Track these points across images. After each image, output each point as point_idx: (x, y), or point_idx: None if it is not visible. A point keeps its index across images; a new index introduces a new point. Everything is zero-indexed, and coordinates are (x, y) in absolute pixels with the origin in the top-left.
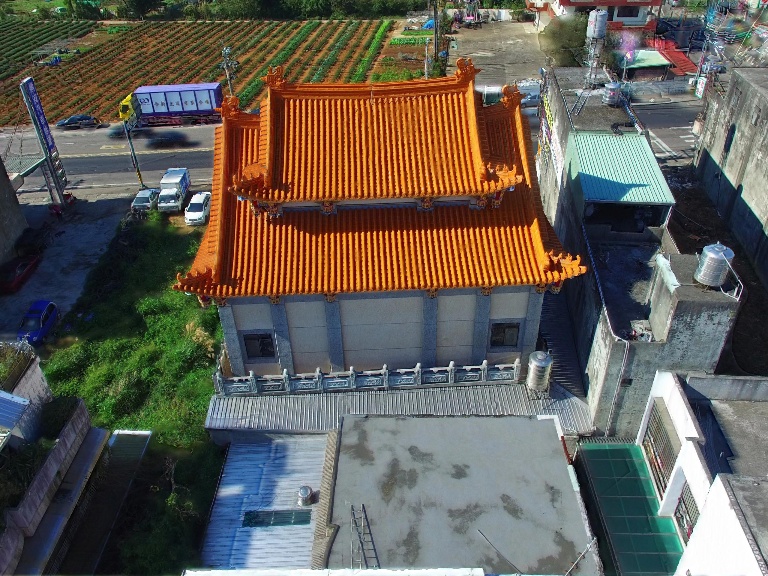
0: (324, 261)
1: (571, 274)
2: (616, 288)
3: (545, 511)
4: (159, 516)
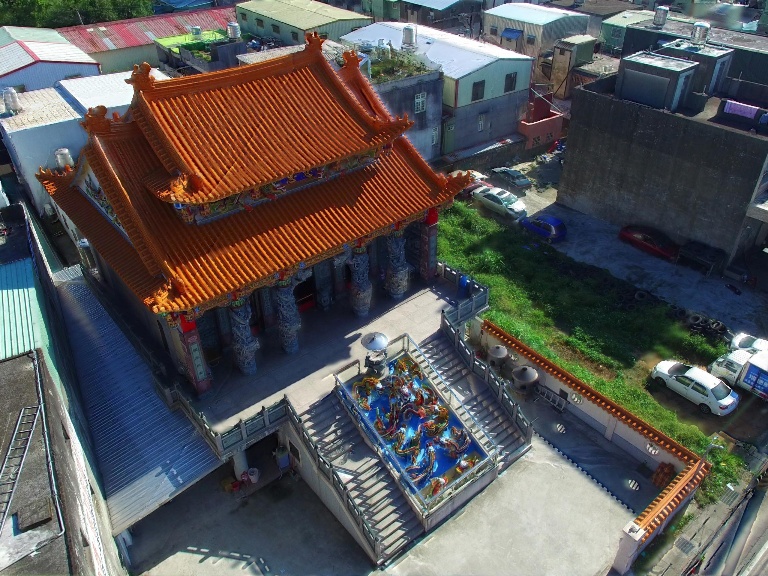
0: None
1: None
2: None
3: None
4: None
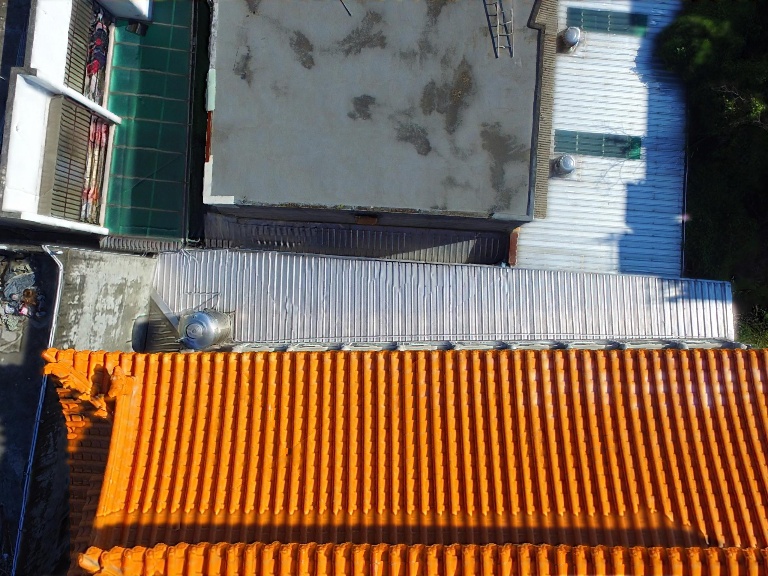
0: (615, 435)
1: (82, 353)
2: (10, 453)
3: (262, 42)
4: (762, 117)
